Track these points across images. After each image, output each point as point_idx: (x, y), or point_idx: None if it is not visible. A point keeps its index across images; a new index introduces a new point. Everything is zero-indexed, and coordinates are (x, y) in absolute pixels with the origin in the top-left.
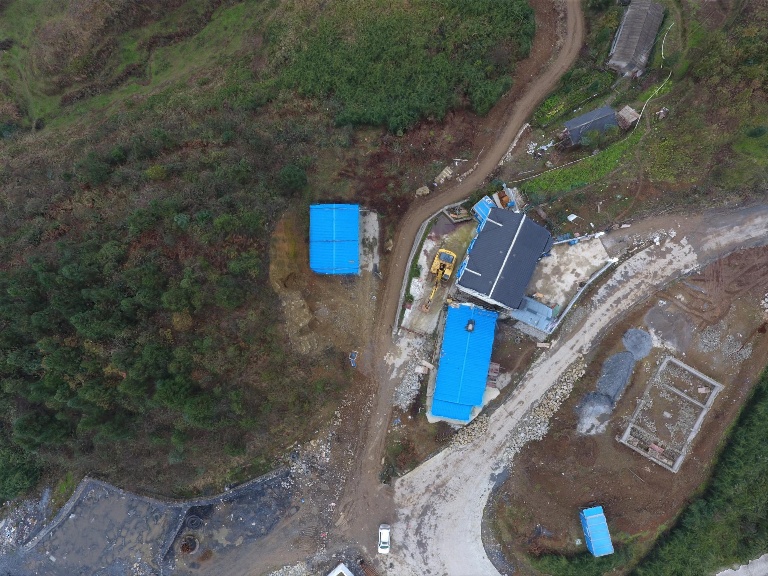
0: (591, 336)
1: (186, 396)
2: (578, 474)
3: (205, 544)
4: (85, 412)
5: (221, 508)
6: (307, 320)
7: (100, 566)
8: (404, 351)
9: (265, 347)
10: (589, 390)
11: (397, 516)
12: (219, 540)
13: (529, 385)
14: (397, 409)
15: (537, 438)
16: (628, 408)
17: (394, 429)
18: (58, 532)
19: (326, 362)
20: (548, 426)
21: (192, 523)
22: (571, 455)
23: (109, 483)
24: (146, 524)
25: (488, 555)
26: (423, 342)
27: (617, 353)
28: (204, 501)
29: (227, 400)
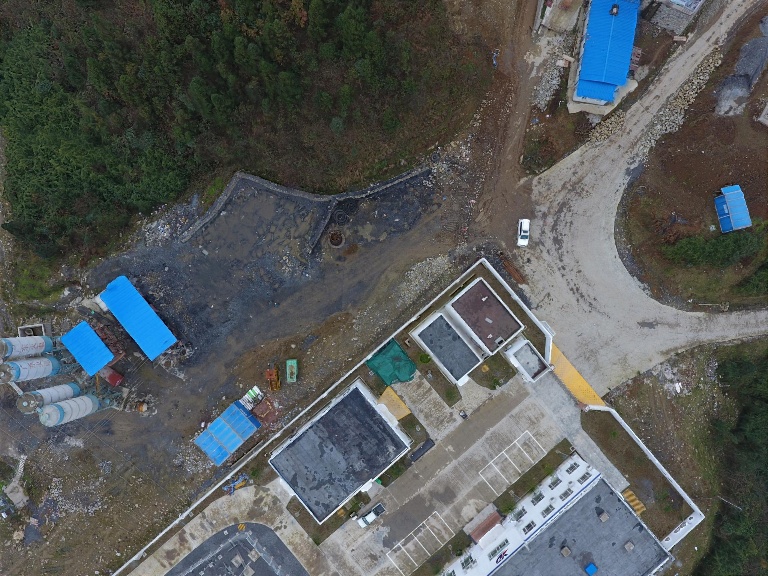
0: (727, 27)
1: (365, 31)
2: (717, 151)
3: (351, 239)
4: (255, 75)
5: (365, 205)
6: (457, 6)
7: (250, 260)
8: (544, 49)
9: (431, 3)
10: (727, 74)
11: (534, 213)
12: (364, 235)
13: (665, 79)
14: (536, 108)
15: (673, 129)
16: (765, 91)
17: (532, 128)
18: (210, 228)
19: (474, 48)
20: (683, 118)
21: (338, 218)
22: (711, 134)
23: (260, 178)
24: (294, 221)
25: (619, 255)
26: (564, 37)
27: (754, 38)
28: (352, 193)
29: (395, 53)
